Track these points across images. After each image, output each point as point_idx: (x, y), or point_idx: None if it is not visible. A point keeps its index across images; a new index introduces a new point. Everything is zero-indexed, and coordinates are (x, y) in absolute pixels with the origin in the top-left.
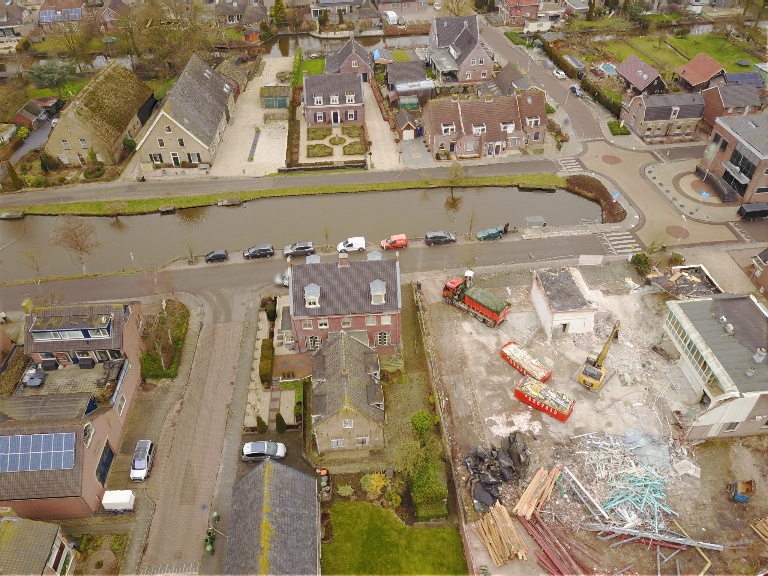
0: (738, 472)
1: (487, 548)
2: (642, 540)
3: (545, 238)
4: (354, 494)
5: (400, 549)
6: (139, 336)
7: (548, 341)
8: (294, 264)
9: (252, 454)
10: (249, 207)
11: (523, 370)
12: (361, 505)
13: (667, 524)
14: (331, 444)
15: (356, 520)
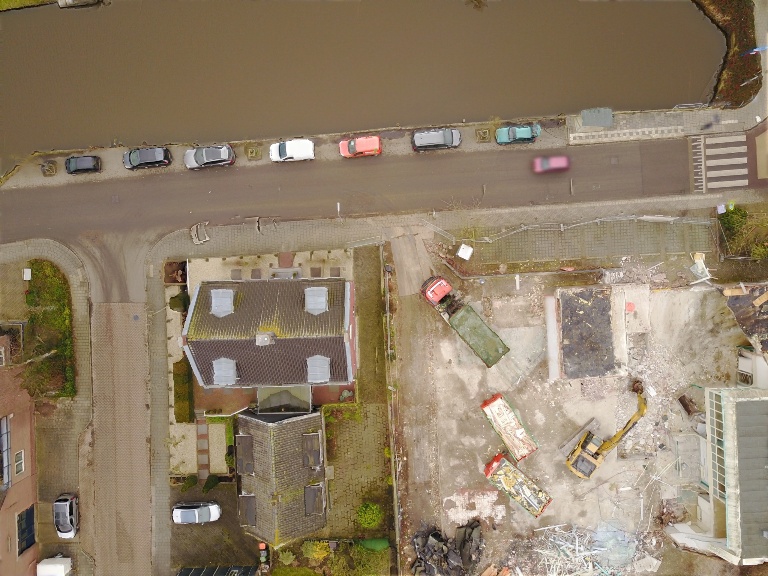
0: (699, 567)
1: None
2: None
3: (605, 144)
4: (296, 559)
5: None
6: (7, 368)
7: (548, 384)
8: (191, 340)
9: None
10: (116, 5)
11: None
12: (303, 572)
13: None
14: None
15: None
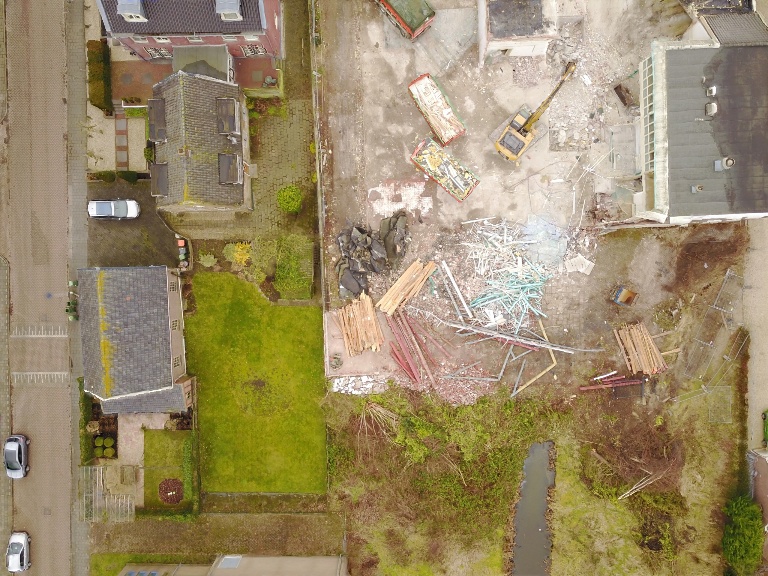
0: (634, 270)
1: (343, 339)
2: (499, 339)
3: None
4: (217, 264)
5: (262, 326)
6: None
7: (478, 68)
8: None
9: (99, 216)
10: None
11: (429, 123)
12: (225, 277)
13: (531, 323)
14: (188, 209)
15: (219, 293)
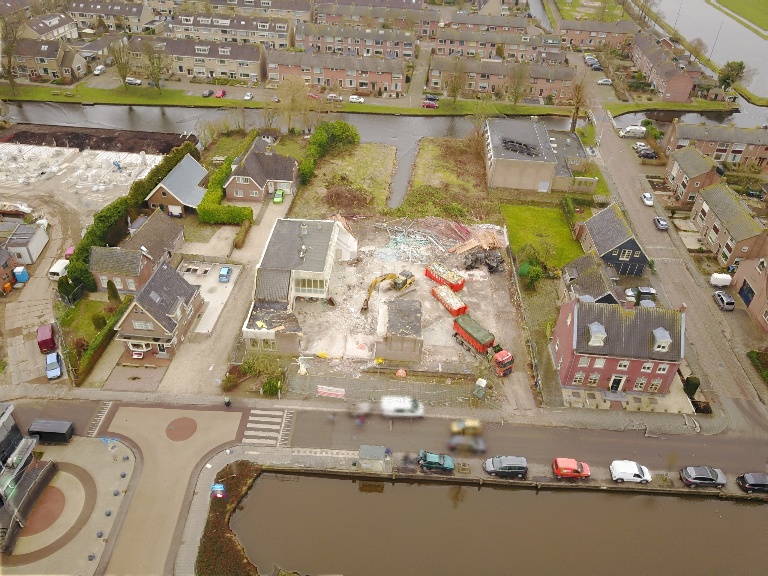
0: None
1: None
2: None
3: None
4: None
5: None
6: None
7: None
8: None
9: None
10: None
11: None
12: None
13: None
14: None
15: None
